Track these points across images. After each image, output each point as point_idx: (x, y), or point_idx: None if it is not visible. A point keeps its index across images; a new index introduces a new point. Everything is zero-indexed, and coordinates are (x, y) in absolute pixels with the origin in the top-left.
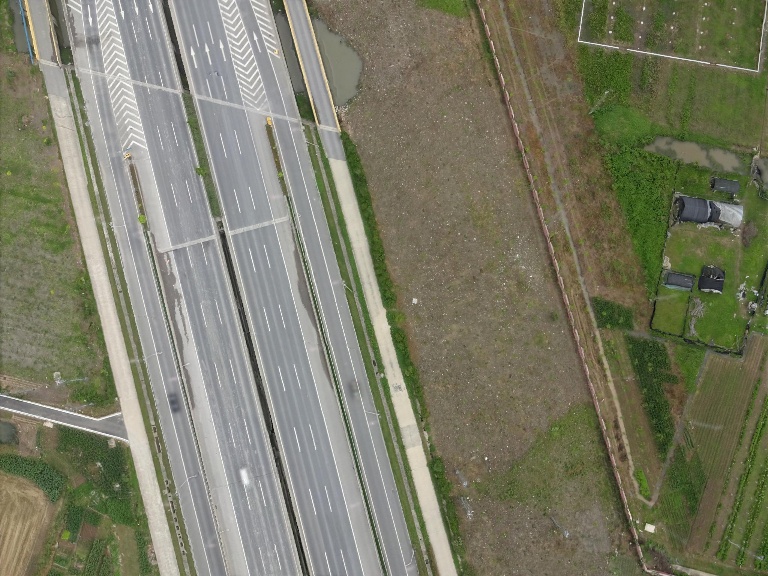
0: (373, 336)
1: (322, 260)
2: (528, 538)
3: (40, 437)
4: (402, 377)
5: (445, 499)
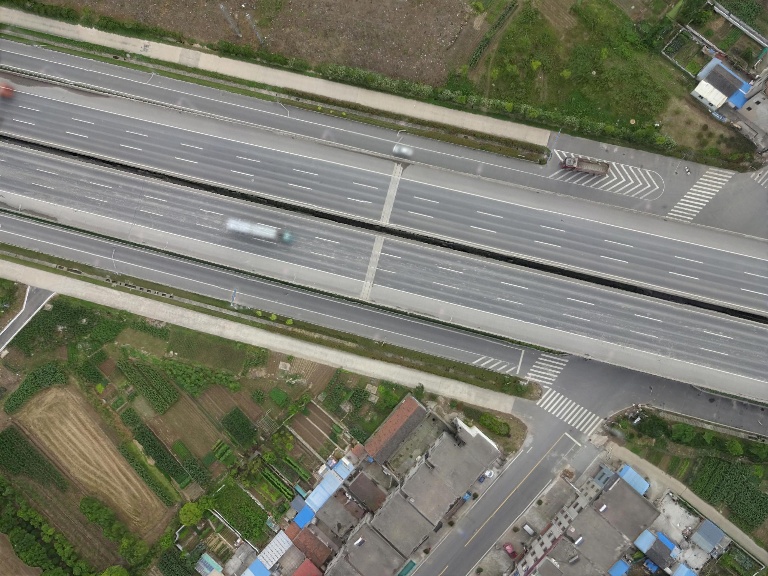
0: (92, 46)
1: (7, 54)
2: (321, 1)
3: (9, 366)
4: (139, 40)
5: (254, 55)
